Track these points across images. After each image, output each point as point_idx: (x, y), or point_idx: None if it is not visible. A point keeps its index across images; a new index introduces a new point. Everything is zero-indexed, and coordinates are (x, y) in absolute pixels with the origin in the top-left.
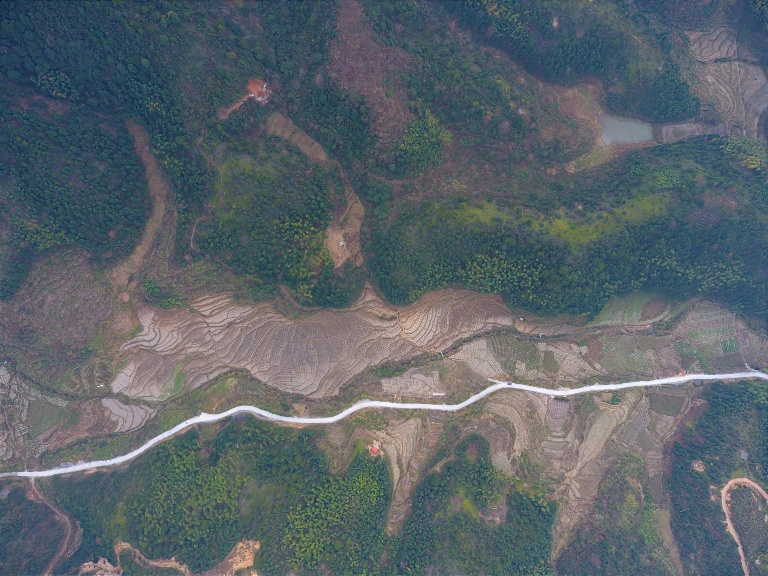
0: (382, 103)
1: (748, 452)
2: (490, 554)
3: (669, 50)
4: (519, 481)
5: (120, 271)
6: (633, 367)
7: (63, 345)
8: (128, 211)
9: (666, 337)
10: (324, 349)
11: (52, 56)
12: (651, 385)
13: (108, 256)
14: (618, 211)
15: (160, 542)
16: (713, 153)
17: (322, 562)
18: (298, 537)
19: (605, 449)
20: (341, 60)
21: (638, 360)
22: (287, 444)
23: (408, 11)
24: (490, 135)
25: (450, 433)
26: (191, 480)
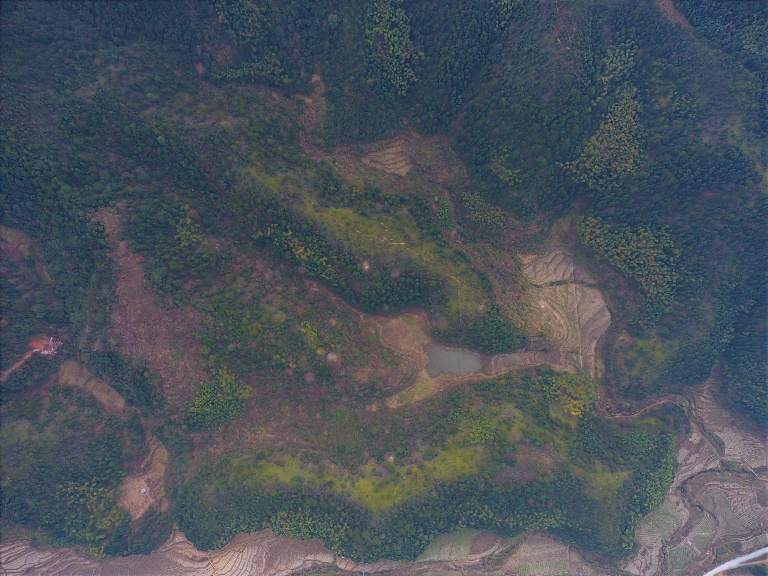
0: (167, 368)
1: None
2: None
3: (490, 289)
4: None
5: None
6: None
7: None
8: None
9: (495, 573)
10: None
11: None
12: None
13: None
14: (429, 465)
15: None
16: (537, 395)
17: None
18: None
19: None
20: (123, 324)
21: None
22: None
23: (203, 262)
24: (298, 381)
25: None
26: None
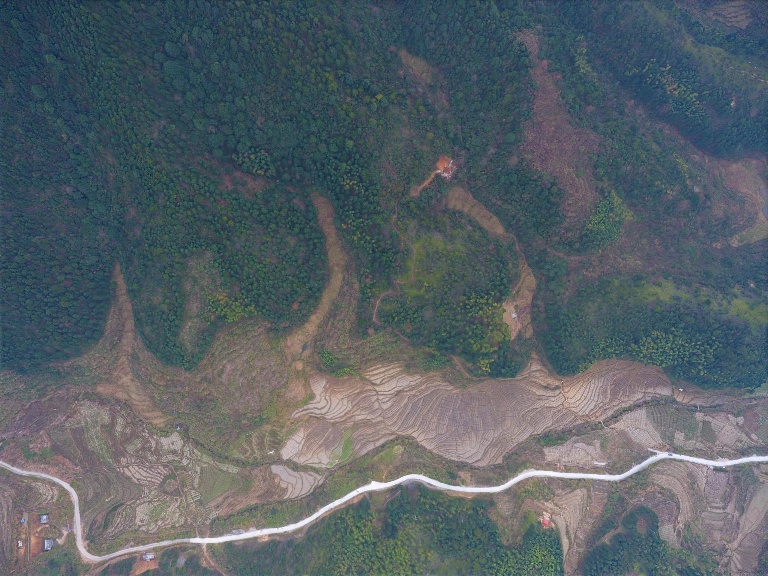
0: (574, 184)
1: None
2: None
3: None
4: (689, 555)
5: (294, 339)
6: None
7: (240, 414)
8: (313, 284)
9: None
10: (489, 417)
11: (259, 136)
12: None
13: (285, 325)
14: None
15: None
16: None
17: None
18: None
19: (764, 521)
20: (535, 141)
21: None
22: (462, 516)
23: (595, 91)
24: (665, 212)
25: (616, 504)
26: (371, 552)
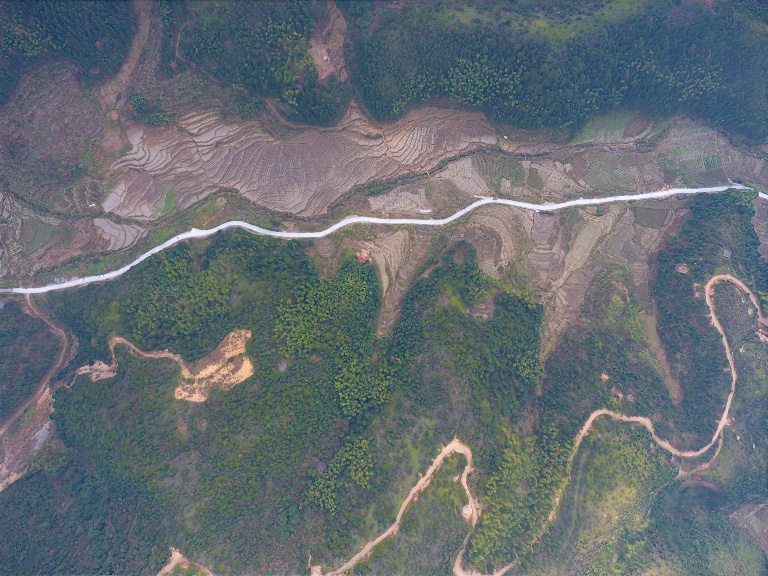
0: None
1: (731, 251)
2: (478, 341)
3: None
4: (506, 282)
5: (108, 90)
6: (617, 183)
7: (54, 160)
8: (114, 20)
9: (649, 153)
10: (311, 168)
11: None
12: (635, 199)
13: (96, 72)
14: (597, 13)
15: (153, 335)
16: None
17: (313, 353)
18: (289, 328)
19: (591, 260)
20: None
21: (622, 176)
22: (277, 250)
23: None
24: None
25: (437, 243)
26: (183, 283)
